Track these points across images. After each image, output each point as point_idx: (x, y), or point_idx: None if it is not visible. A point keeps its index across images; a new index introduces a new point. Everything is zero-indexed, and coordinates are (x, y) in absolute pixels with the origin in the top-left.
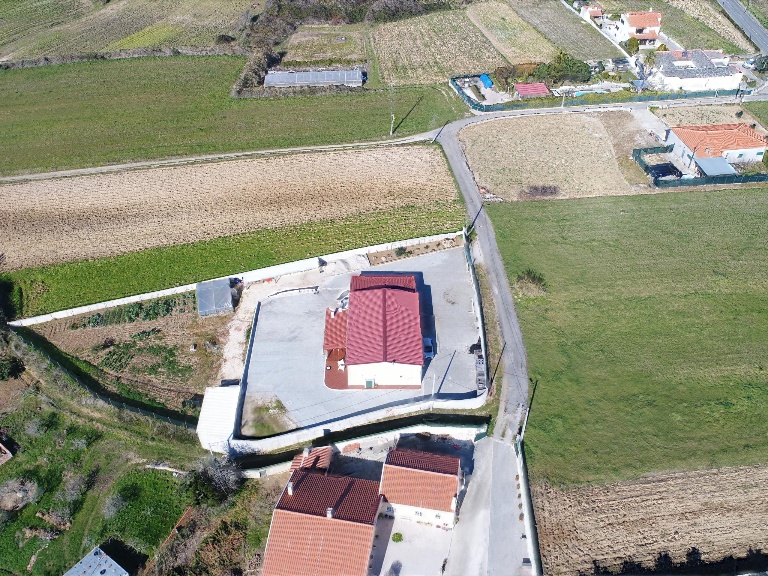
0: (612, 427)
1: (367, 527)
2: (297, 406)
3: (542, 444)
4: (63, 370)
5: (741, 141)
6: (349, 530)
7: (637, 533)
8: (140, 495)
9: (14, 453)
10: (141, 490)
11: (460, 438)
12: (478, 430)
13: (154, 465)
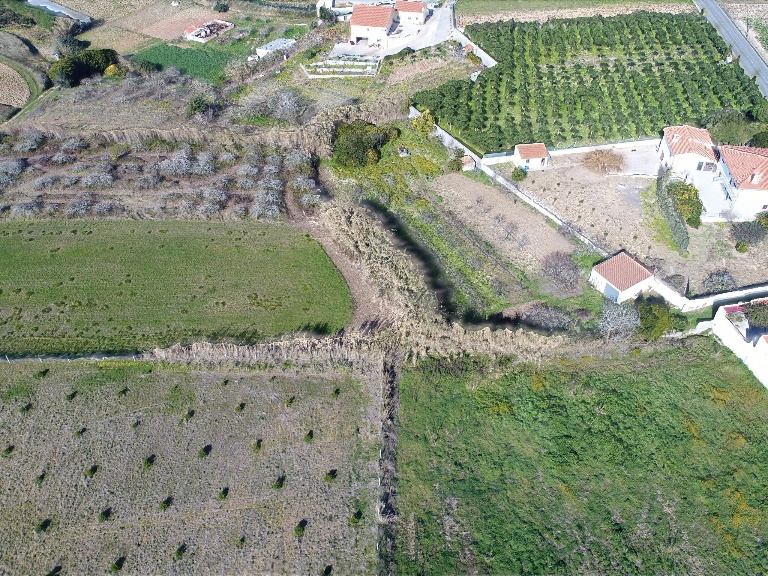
0: (492, 3)
1: (390, 7)
2: (358, 3)
3: (462, 7)
4: (250, 2)
5: None
6: (383, 8)
7: None
8: (293, 31)
9: (235, 26)
10: (294, 30)
11: (428, 8)
12: (436, 4)
13: (298, 24)
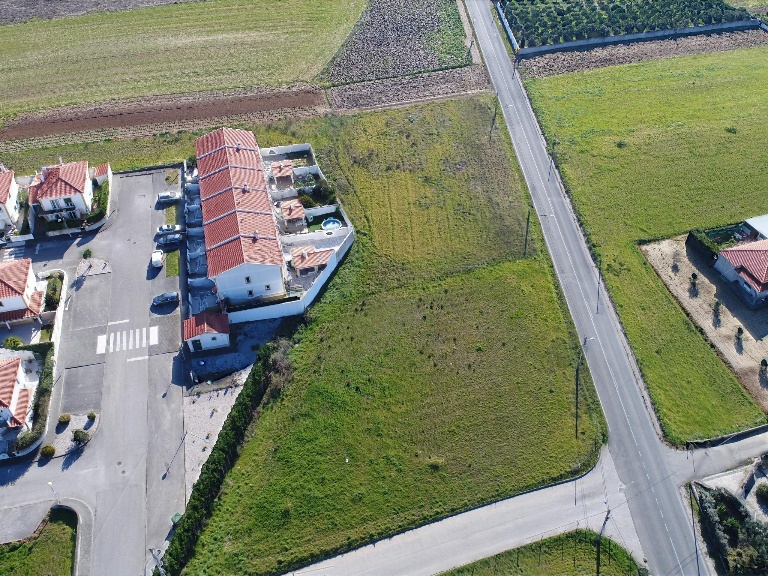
0: (762, 59)
1: None
2: None
3: None
4: None
5: (760, 242)
6: None
7: (733, 38)
8: None
9: None
10: None
11: None
12: None
13: None
